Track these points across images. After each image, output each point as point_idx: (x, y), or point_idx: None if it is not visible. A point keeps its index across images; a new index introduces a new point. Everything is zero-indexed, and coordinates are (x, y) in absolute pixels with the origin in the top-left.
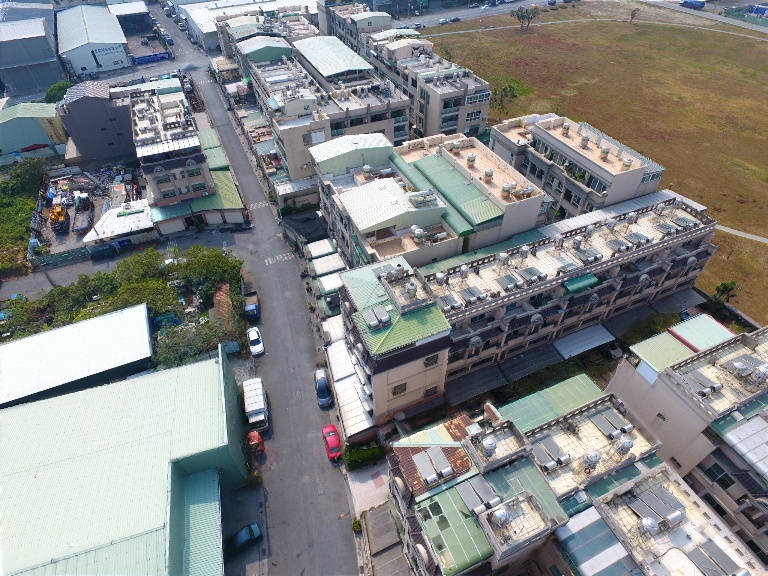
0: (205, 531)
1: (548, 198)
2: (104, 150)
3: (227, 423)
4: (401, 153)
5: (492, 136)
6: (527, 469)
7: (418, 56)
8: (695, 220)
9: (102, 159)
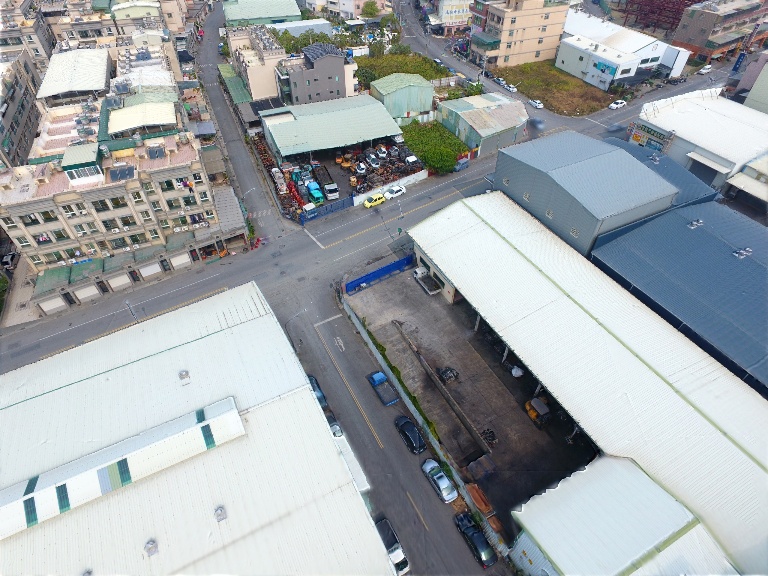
0: None
1: None
2: None
3: (223, 4)
4: (106, 24)
5: None
6: None
7: None
8: None
9: None
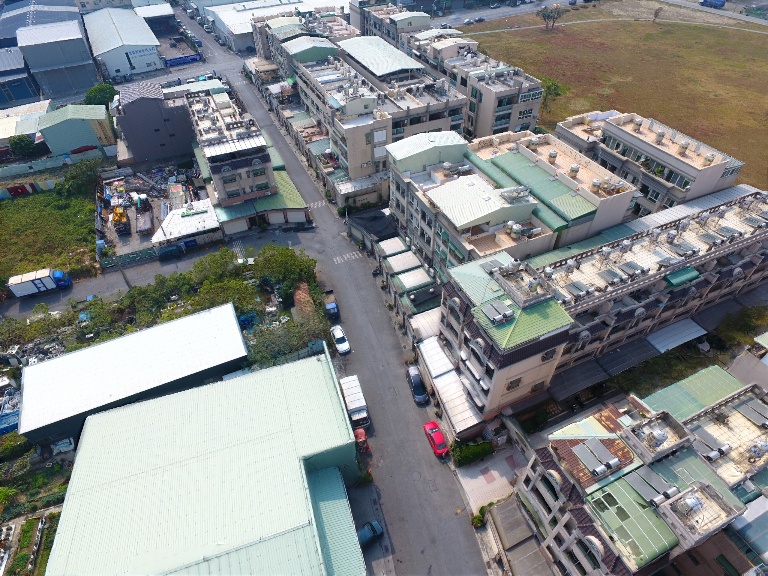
0: (340, 528)
1: (637, 193)
2: (156, 151)
3: (348, 420)
4: None
5: (557, 133)
6: (691, 459)
7: (465, 55)
8: None
9: (153, 160)
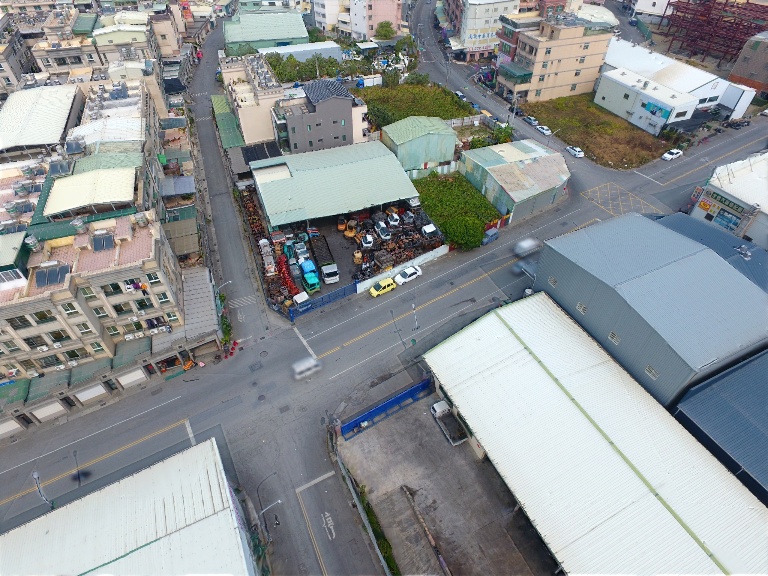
0: None
1: None
2: None
3: None
4: (86, 50)
5: (6, 59)
6: None
7: None
8: None
9: None
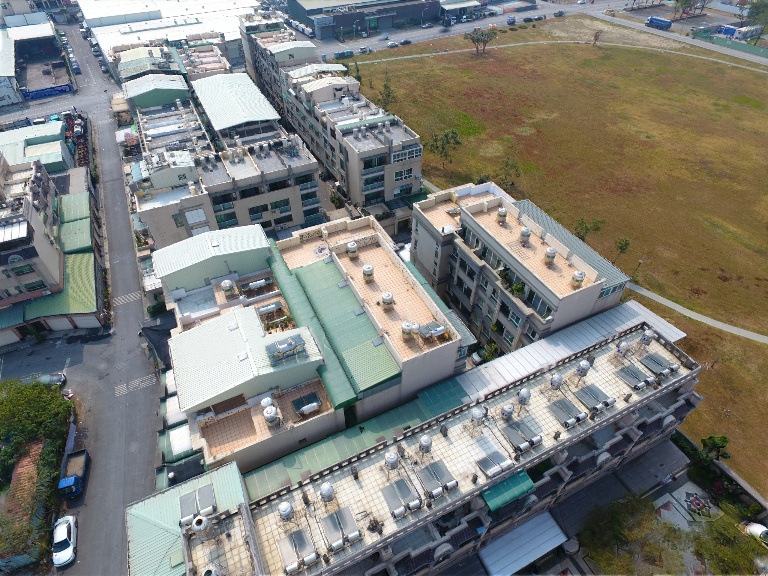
0: None
1: (468, 338)
2: None
3: None
4: (290, 246)
5: (414, 215)
6: None
7: (340, 99)
8: (671, 360)
9: None
